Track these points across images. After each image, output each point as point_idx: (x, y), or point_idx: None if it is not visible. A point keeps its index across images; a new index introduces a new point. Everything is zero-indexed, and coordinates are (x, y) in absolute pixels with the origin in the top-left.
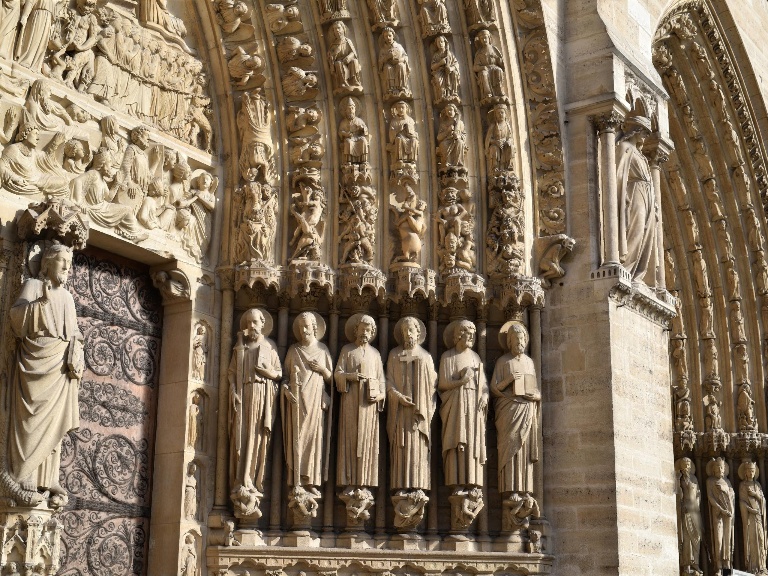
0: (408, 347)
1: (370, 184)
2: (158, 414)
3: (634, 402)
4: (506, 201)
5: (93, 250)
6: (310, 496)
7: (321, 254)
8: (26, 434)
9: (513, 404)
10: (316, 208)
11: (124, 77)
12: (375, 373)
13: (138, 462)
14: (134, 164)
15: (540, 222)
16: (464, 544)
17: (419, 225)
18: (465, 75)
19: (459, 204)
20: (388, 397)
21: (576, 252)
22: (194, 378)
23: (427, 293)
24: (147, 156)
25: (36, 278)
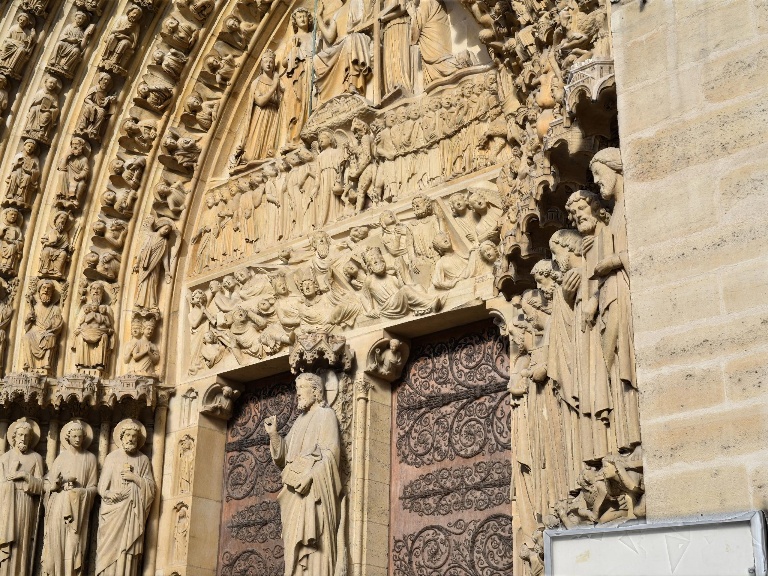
0: None
1: None
2: None
3: (731, 156)
4: None
5: (452, 332)
6: None
7: None
8: None
9: None
10: None
11: None
12: None
13: None
14: None
15: None
16: None
17: (540, 98)
18: None
19: None
20: None
21: None
22: None
23: (535, 192)
24: (434, 219)
25: None
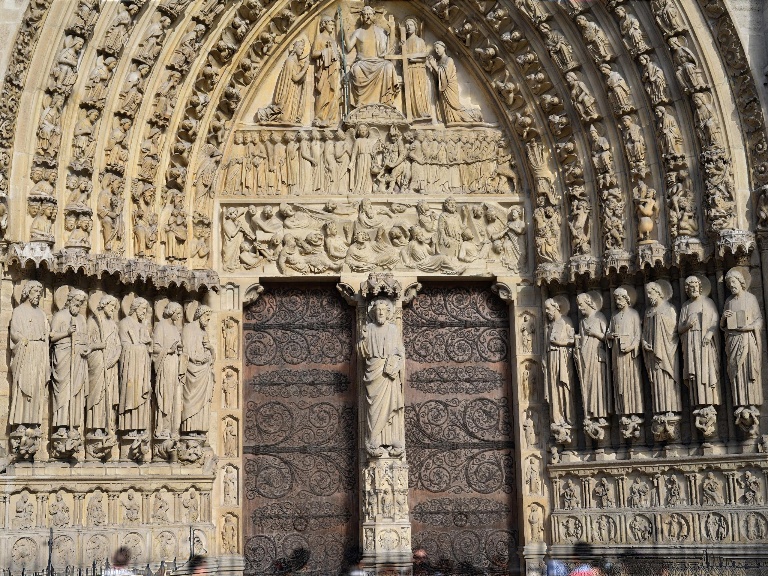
0: (652, 305)
1: (618, 185)
2: (512, 379)
3: None
4: (708, 173)
5: (445, 283)
6: (596, 425)
7: (588, 248)
8: (371, 416)
9: (730, 337)
10: (579, 216)
11: (434, 169)
12: (632, 329)
13: (501, 413)
14: (446, 225)
15: (753, 177)
16: (710, 450)
17: (646, 210)
18: (672, 77)
19: (678, 184)
20: None
21: None
22: (524, 353)
23: (652, 263)
24: (459, 215)
25: (372, 322)
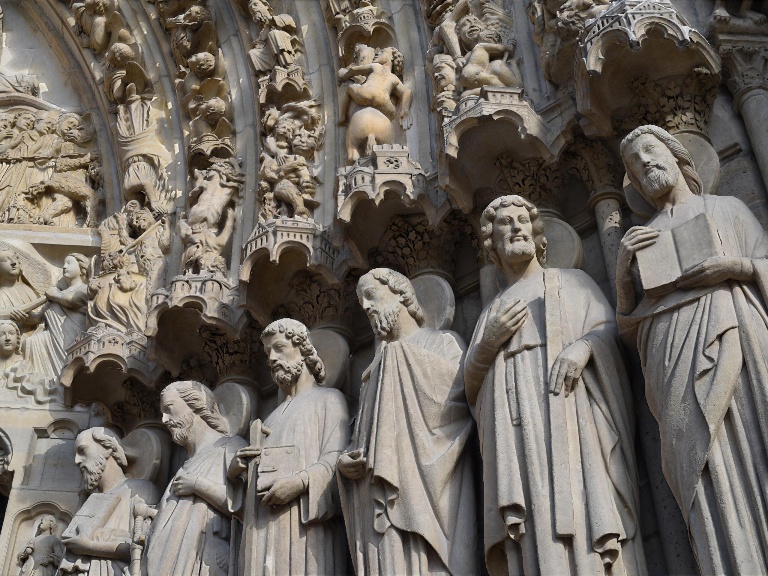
0: (380, 340)
1: (311, 98)
2: None
3: None
4: None
5: None
6: None
7: (217, 264)
8: None
9: (656, 325)
10: (204, 192)
11: None
12: (311, 439)
13: None
14: None
15: None
16: None
17: (368, 88)
18: None
19: None
20: None
21: None
22: None
23: (373, 191)
24: None
25: None
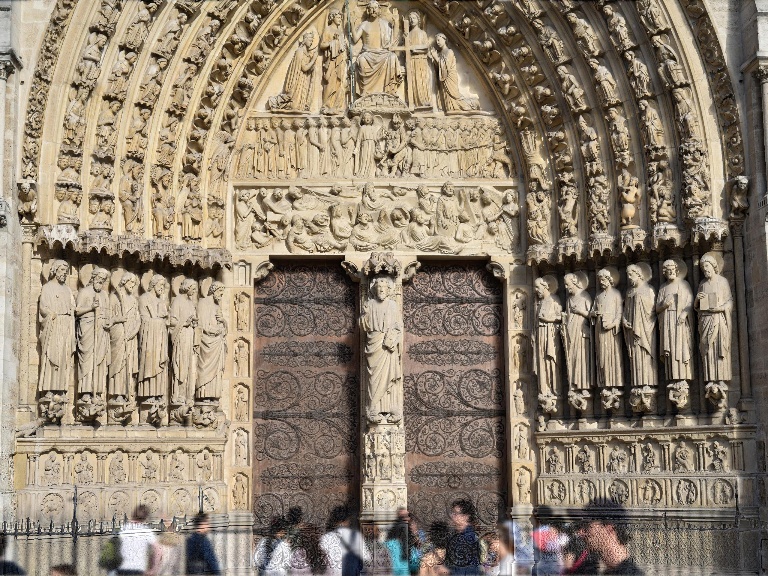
0: None
1: (604, 173)
2: (504, 352)
3: None
4: (686, 164)
5: (443, 262)
6: (579, 396)
7: (575, 232)
8: (371, 385)
9: (702, 317)
10: (568, 201)
11: (433, 155)
12: (614, 308)
13: (494, 383)
14: (444, 208)
15: (728, 168)
16: (682, 421)
17: (629, 197)
18: (655, 72)
19: (659, 173)
20: (622, 324)
21: (752, 187)
22: (515, 328)
23: (633, 247)
24: (456, 198)
25: (373, 298)
